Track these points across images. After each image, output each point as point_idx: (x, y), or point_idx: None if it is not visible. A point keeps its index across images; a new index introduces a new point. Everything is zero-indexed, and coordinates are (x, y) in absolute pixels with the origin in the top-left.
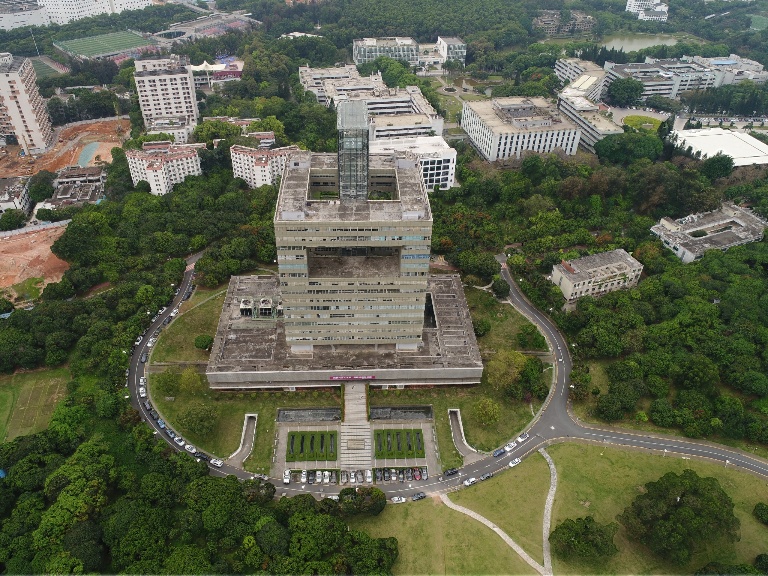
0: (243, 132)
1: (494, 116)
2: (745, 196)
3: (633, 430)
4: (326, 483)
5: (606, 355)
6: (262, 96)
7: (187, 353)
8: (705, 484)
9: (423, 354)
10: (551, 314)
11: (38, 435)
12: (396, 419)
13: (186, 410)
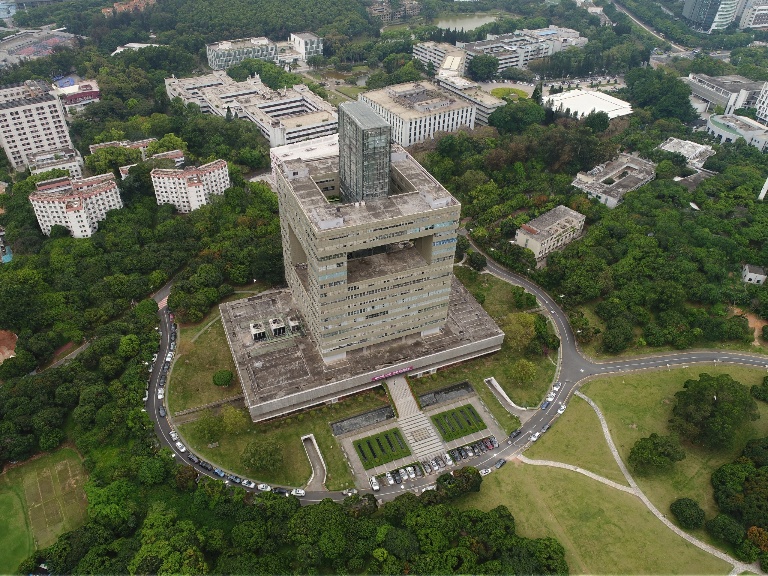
0: (141, 155)
1: (394, 104)
2: (624, 144)
3: (637, 355)
4: (413, 478)
5: (590, 298)
6: (137, 115)
7: (206, 394)
8: (726, 380)
9: (448, 335)
10: (528, 274)
11: (89, 525)
12: (444, 401)
13: (250, 449)
